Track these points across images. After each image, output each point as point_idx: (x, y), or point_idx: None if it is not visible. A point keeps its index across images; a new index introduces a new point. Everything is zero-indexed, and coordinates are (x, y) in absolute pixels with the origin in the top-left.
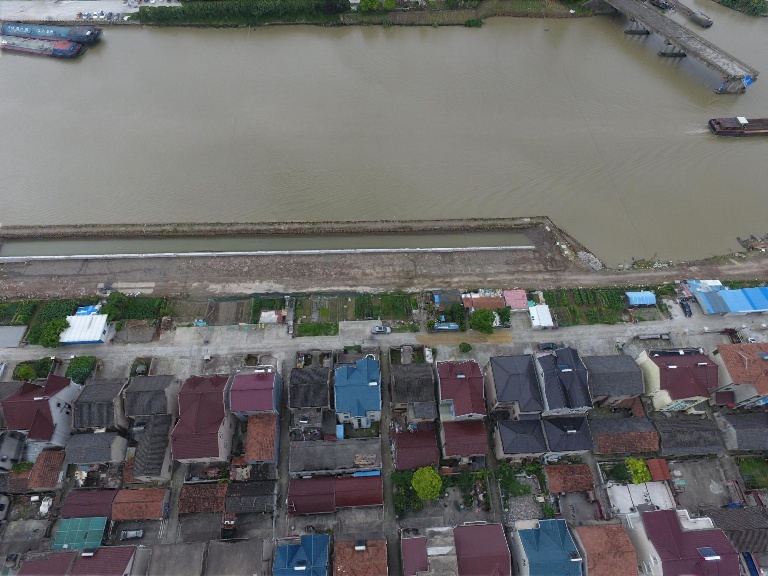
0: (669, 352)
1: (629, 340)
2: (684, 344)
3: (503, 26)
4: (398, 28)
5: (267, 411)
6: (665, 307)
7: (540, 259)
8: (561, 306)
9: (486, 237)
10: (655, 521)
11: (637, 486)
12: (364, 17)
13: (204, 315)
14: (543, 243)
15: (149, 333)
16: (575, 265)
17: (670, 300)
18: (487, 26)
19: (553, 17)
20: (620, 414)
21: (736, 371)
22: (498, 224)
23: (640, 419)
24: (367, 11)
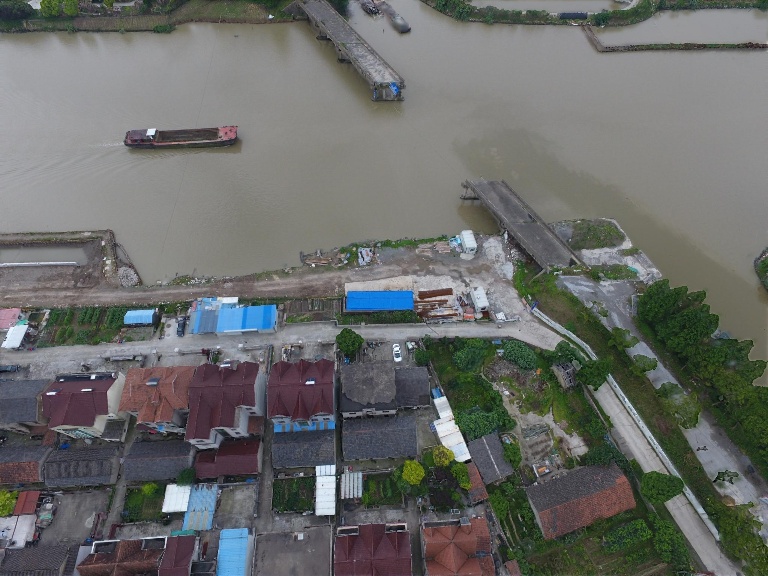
0: (79, 377)
1: (102, 362)
2: (154, 366)
3: (195, 32)
4: (83, 34)
5: None
6: (162, 326)
7: (76, 275)
8: (62, 325)
9: (41, 252)
10: None
11: (7, 520)
12: (49, 23)
13: None
14: (94, 258)
15: None
16: (106, 282)
17: (173, 319)
18: (180, 32)
19: (251, 23)
20: (41, 441)
21: (124, 397)
22: (53, 238)
23: (39, 448)
24: (49, 17)
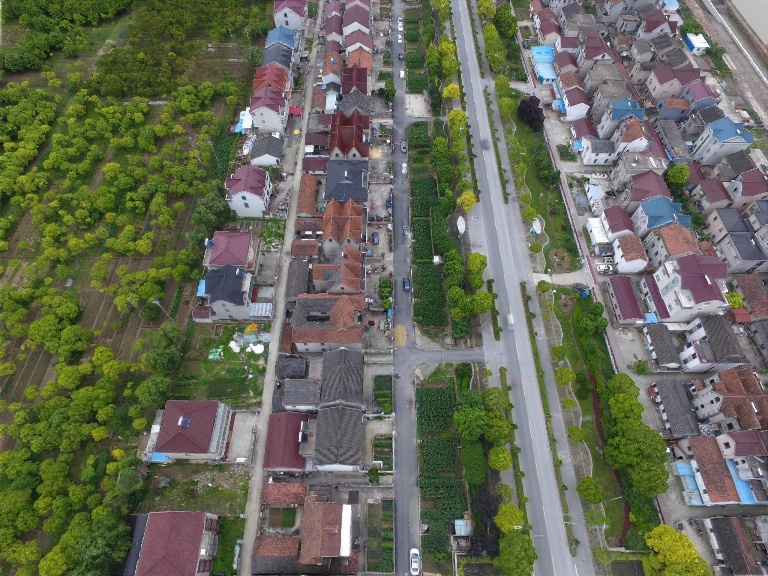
0: None
1: None
2: None
3: None
4: None
5: (692, 102)
6: None
7: None
8: None
9: None
10: None
11: None
12: None
13: (728, 90)
14: None
15: (705, 68)
16: None
17: None
18: None
19: None
20: None
21: None
22: None
23: None
24: None
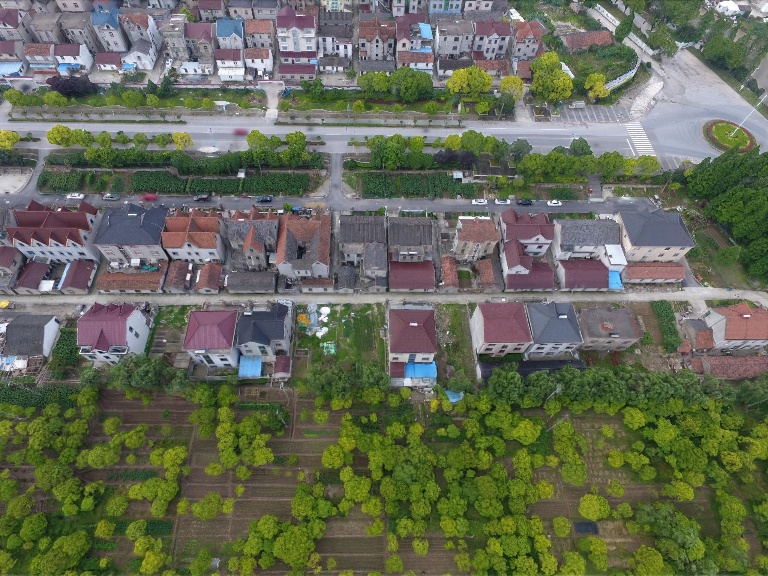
0: None
1: None
2: None
3: None
4: None
5: None
6: None
7: None
8: None
9: None
10: (282, 10)
11: None
12: None
13: None
14: None
15: None
16: None
17: None
18: None
19: None
20: None
21: None
22: None
23: None
24: None
